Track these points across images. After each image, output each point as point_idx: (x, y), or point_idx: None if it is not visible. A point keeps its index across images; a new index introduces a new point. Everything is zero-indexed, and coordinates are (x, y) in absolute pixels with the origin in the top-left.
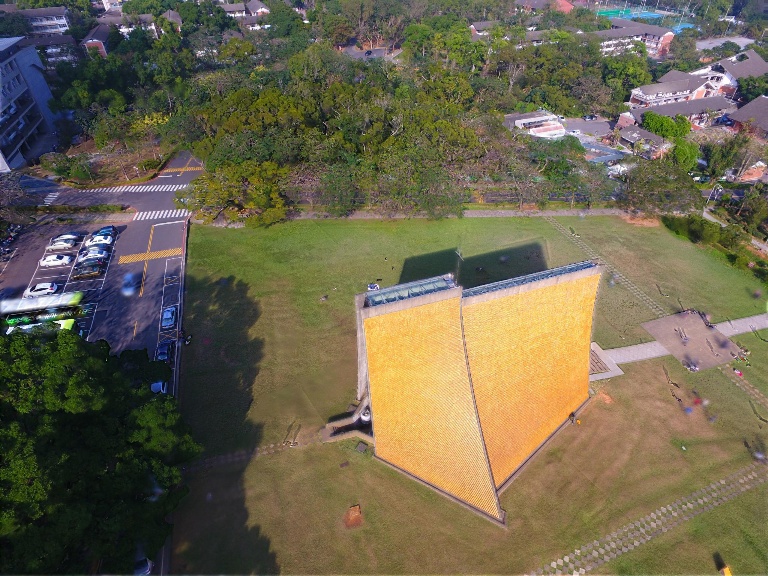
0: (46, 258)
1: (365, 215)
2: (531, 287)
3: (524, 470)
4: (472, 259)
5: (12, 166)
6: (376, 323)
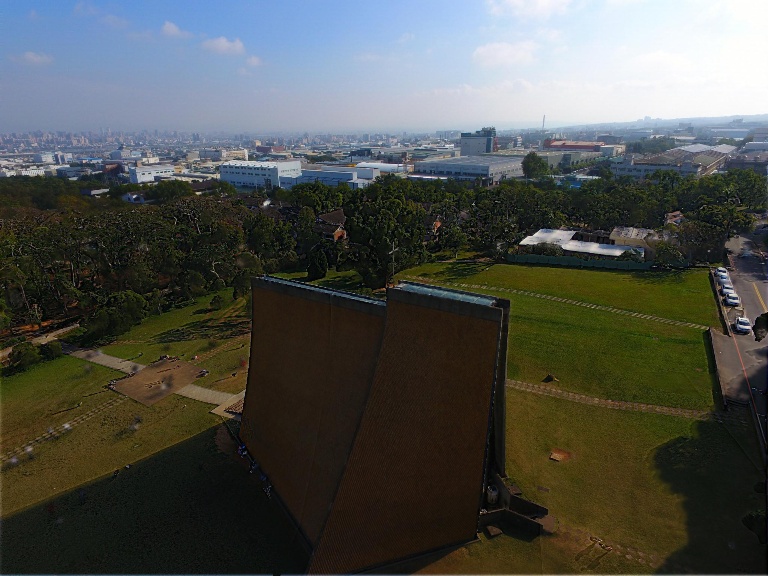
0: None
1: None
2: None
3: None
4: None
5: None
6: None
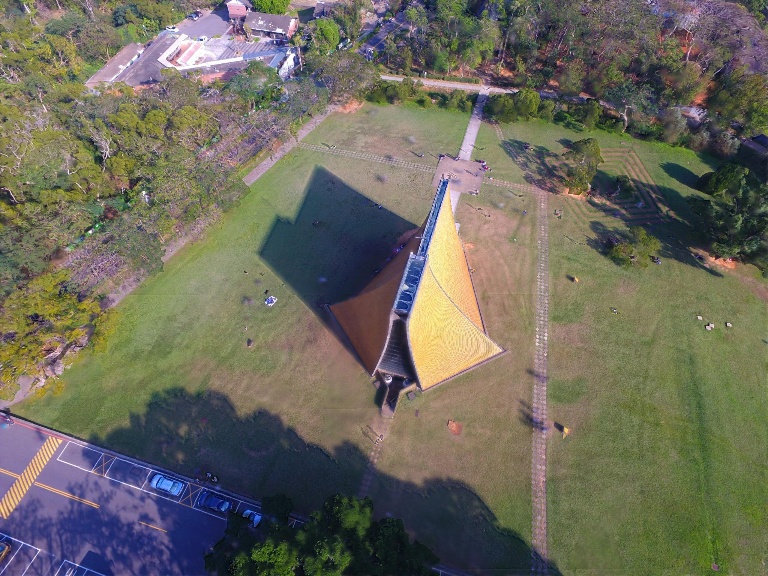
0: None
1: (170, 250)
2: (437, 221)
3: (484, 318)
4: (300, 220)
5: None
6: (411, 319)
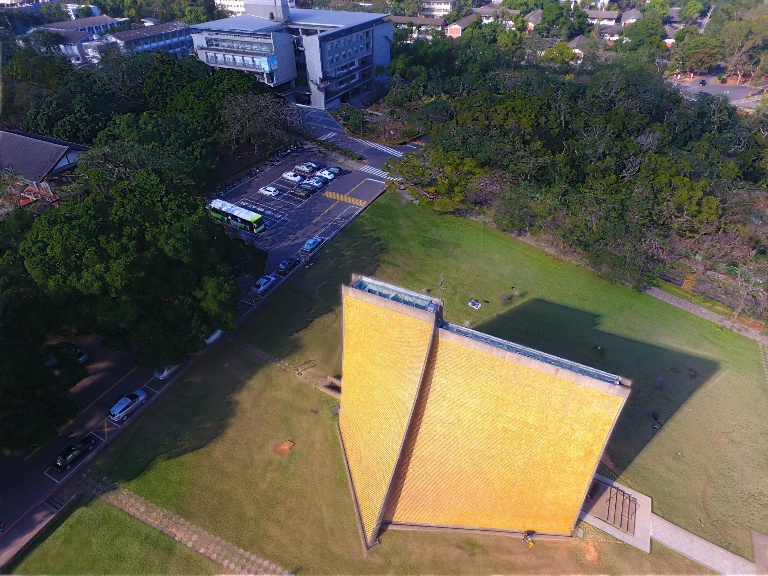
0: (288, 173)
1: None
2: (521, 361)
3: (431, 531)
4: (603, 335)
5: (327, 106)
6: (354, 304)
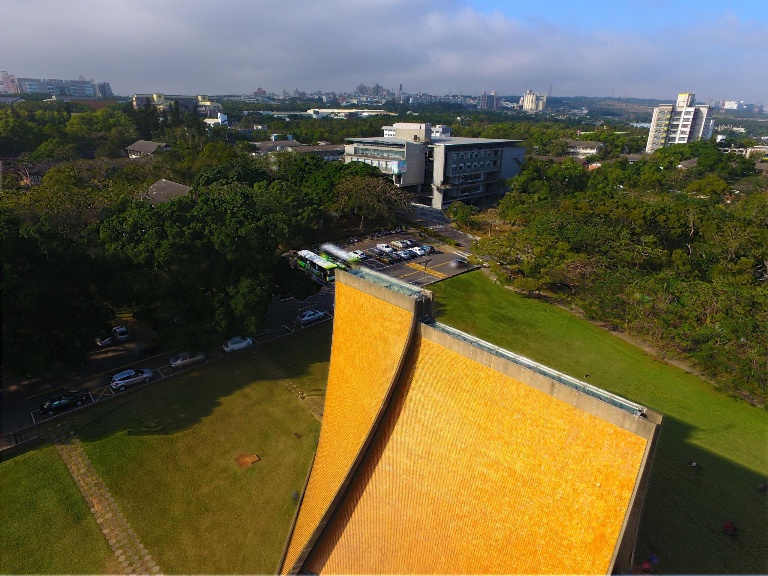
0: (381, 244)
1: None
2: (509, 370)
3: None
4: (705, 452)
5: (444, 207)
6: (344, 292)
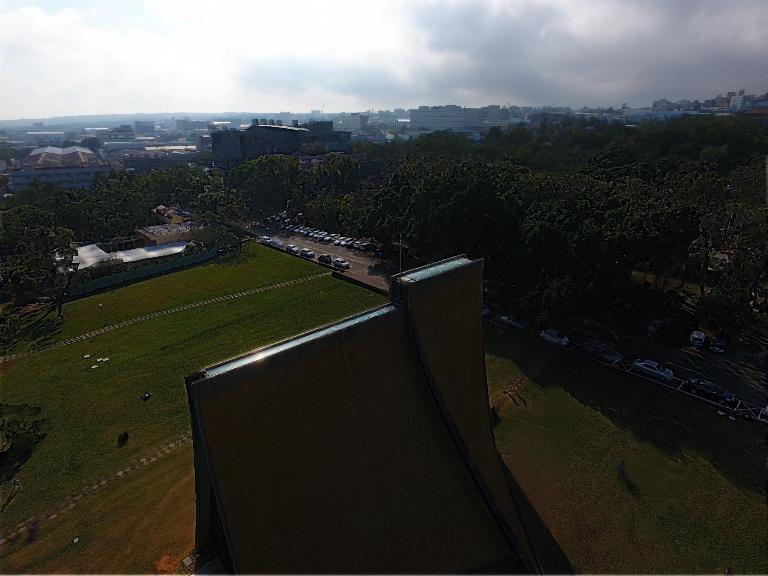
0: None
1: None
2: None
3: None
4: None
5: None
6: None
